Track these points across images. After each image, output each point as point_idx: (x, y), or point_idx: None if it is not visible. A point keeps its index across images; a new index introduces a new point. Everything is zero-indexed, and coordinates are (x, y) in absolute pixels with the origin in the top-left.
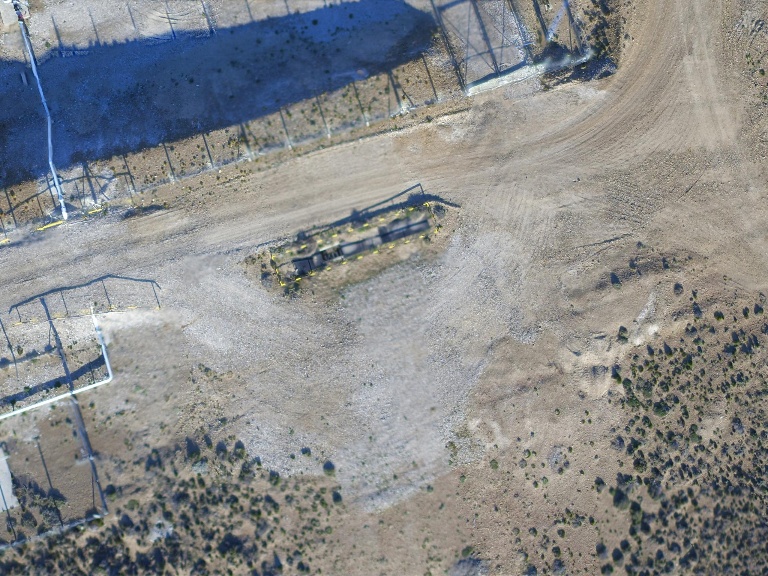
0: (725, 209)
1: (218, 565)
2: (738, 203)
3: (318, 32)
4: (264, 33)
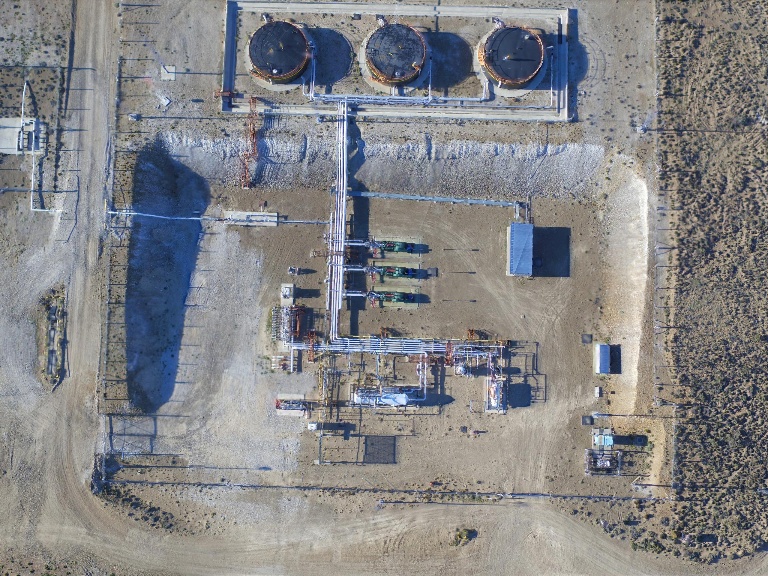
0: (8, 522)
1: None
2: (8, 529)
3: (168, 356)
4: (177, 330)
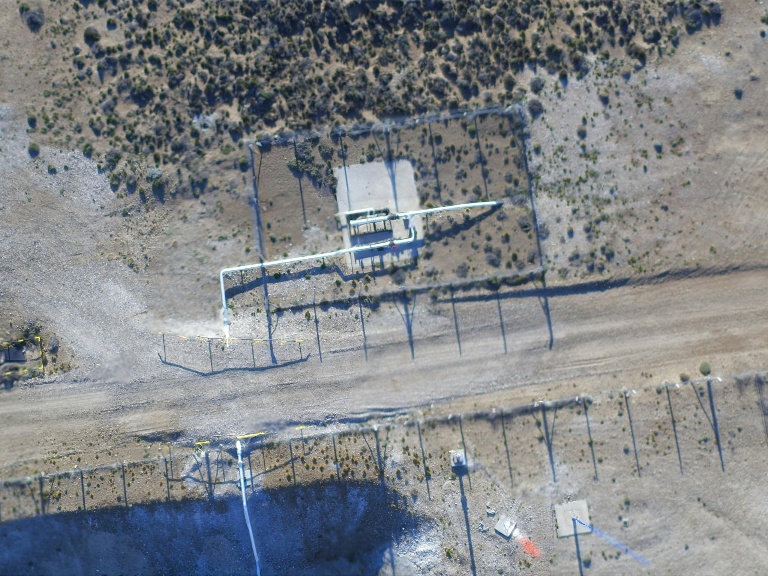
0: None
1: (158, 81)
2: None
3: None
4: None
